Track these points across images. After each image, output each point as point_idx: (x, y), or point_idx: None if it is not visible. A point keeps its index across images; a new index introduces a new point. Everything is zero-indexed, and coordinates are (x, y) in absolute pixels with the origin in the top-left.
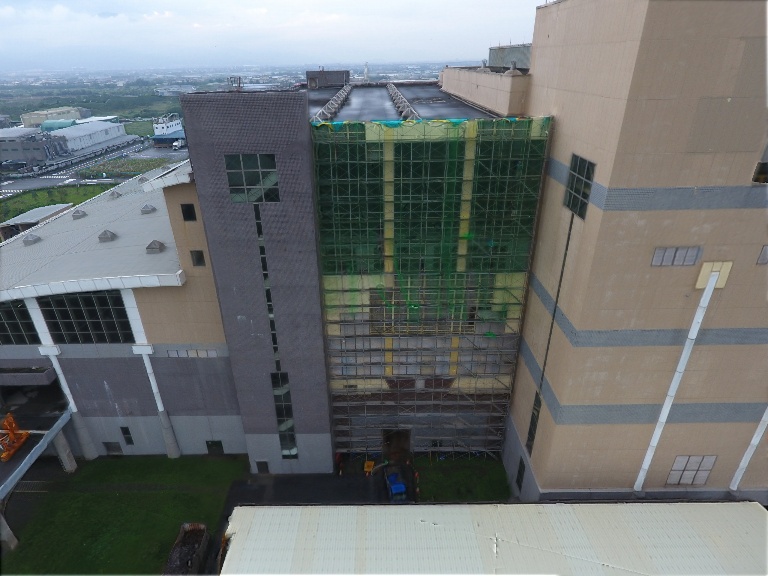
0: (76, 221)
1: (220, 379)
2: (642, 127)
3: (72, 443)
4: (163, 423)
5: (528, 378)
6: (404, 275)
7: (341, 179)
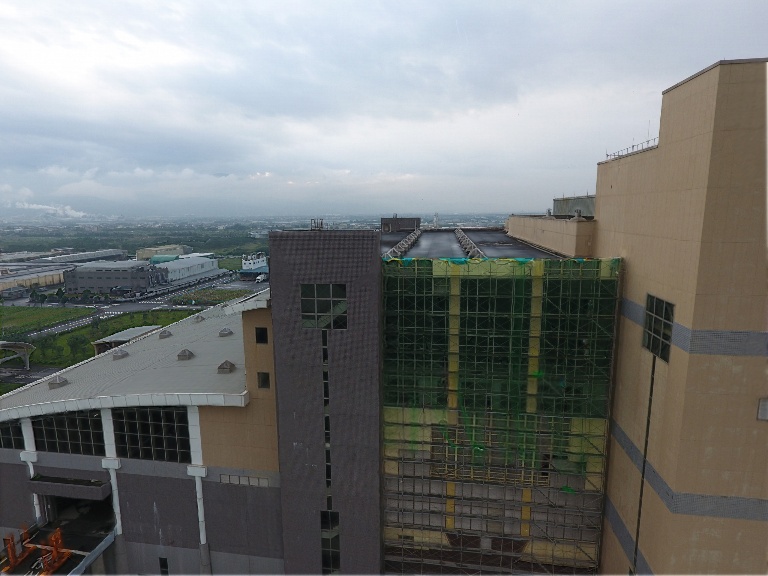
0: (161, 340)
1: (268, 513)
2: (722, 268)
3: (109, 571)
4: (202, 558)
5: (618, 550)
6: (469, 412)
7: (407, 310)
